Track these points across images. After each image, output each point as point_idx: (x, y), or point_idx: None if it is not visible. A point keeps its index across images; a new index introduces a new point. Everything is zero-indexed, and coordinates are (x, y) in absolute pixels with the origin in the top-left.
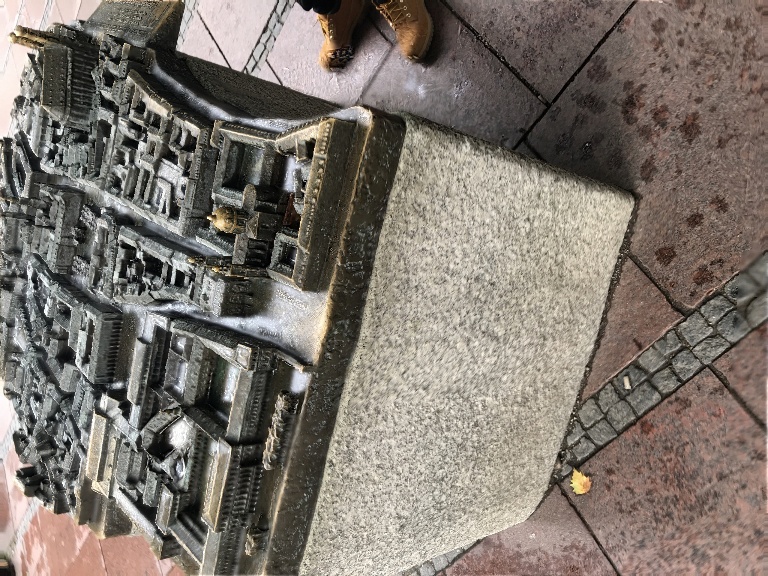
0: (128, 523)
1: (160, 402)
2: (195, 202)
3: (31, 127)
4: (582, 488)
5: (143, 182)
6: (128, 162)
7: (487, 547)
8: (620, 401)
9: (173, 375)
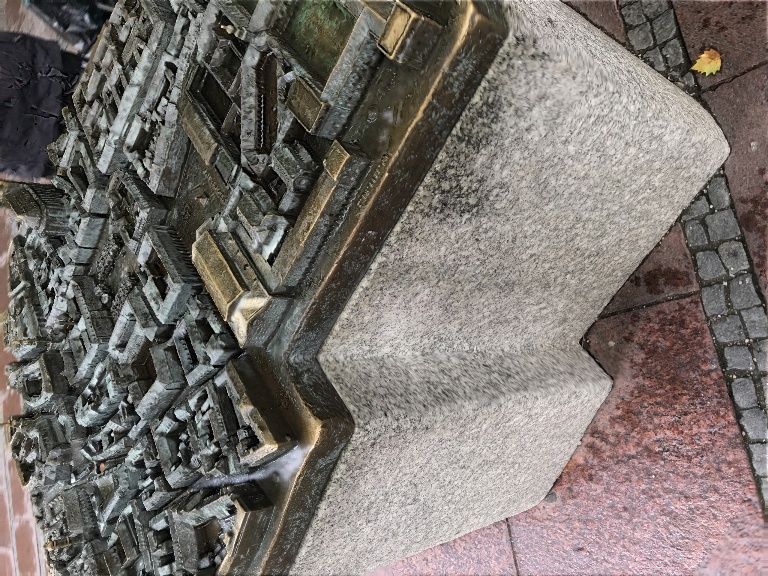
0: (339, 404)
1: (239, 129)
2: (157, 3)
3: (26, 329)
4: (714, 62)
5: (119, 94)
6: None
7: (752, 225)
8: (641, 0)
9: (228, 79)
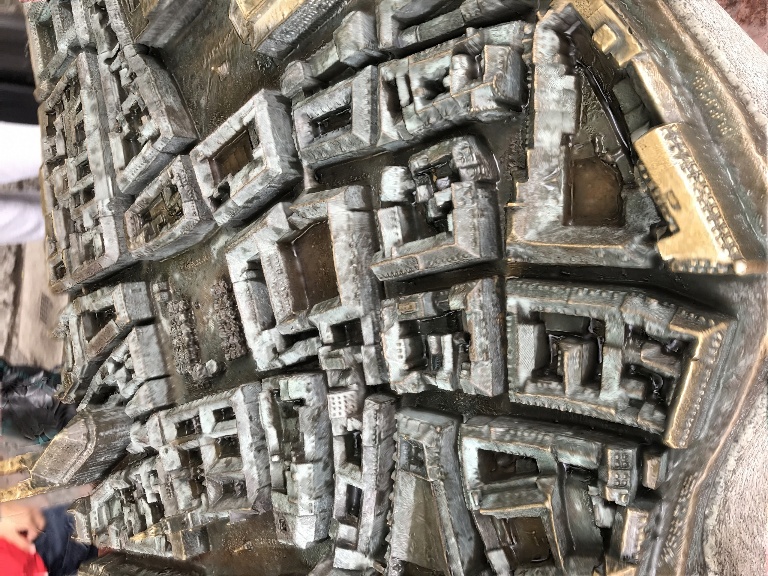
0: None
1: None
2: None
3: None
4: None
5: None
6: (88, 231)
7: None
8: None
9: None
